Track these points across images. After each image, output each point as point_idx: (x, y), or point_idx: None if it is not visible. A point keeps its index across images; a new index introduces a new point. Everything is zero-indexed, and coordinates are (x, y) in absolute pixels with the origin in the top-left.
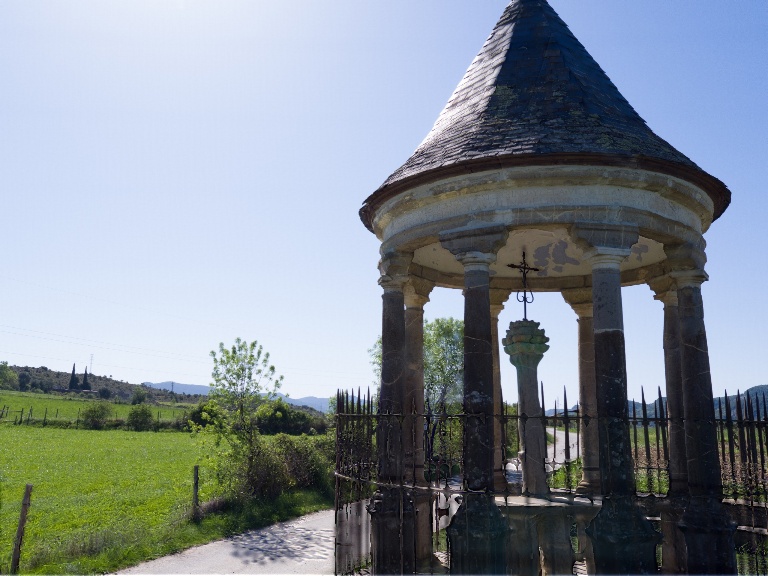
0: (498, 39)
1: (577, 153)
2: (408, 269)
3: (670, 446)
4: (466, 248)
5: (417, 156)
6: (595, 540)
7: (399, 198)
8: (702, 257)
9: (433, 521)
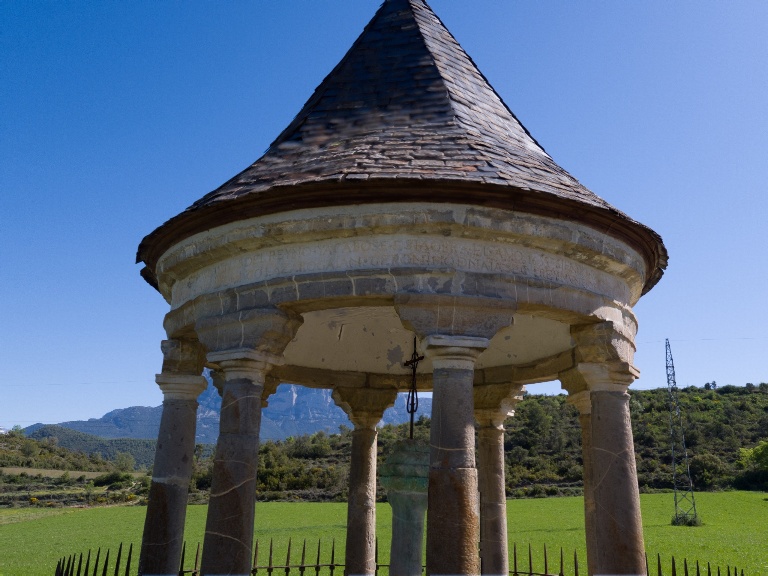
0: None
1: None
2: (350, 404)
3: None
4: None
5: None
6: None
7: None
8: (231, 325)
9: None
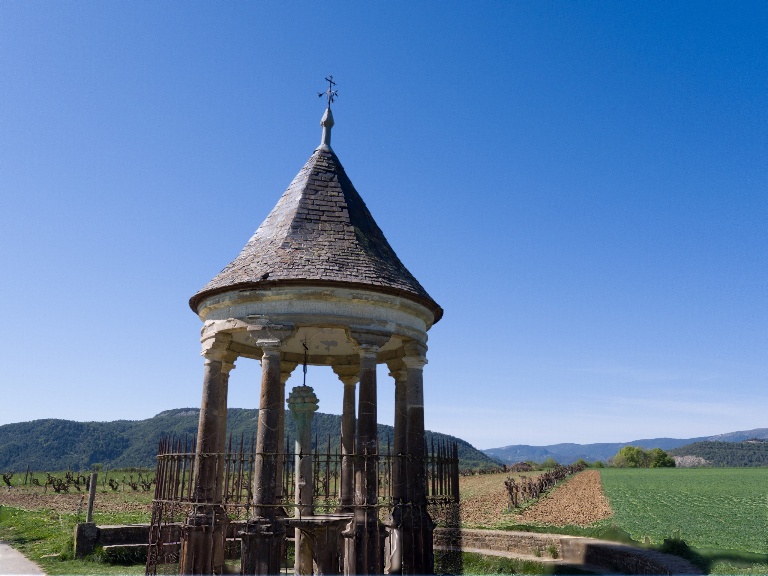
0: (327, 181)
1: (428, 300)
2: None
3: (345, 478)
4: (371, 341)
5: (324, 260)
6: (409, 532)
7: (318, 289)
8: None
9: (11, 571)
